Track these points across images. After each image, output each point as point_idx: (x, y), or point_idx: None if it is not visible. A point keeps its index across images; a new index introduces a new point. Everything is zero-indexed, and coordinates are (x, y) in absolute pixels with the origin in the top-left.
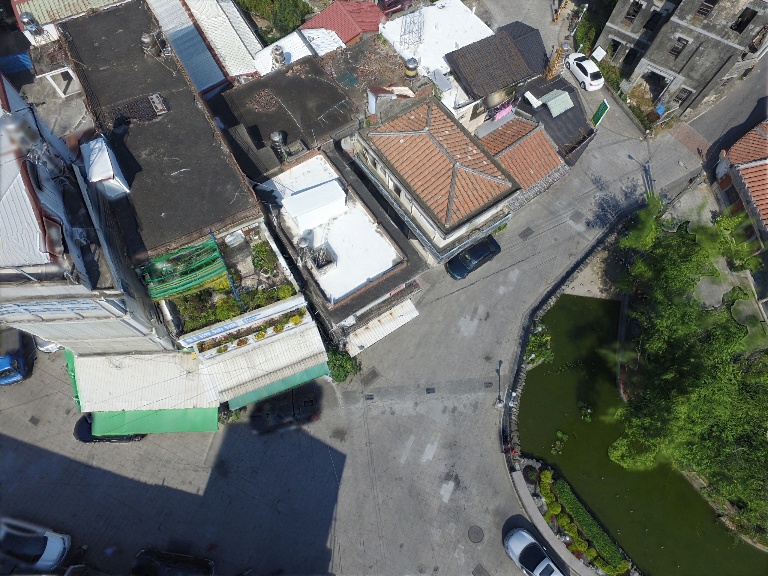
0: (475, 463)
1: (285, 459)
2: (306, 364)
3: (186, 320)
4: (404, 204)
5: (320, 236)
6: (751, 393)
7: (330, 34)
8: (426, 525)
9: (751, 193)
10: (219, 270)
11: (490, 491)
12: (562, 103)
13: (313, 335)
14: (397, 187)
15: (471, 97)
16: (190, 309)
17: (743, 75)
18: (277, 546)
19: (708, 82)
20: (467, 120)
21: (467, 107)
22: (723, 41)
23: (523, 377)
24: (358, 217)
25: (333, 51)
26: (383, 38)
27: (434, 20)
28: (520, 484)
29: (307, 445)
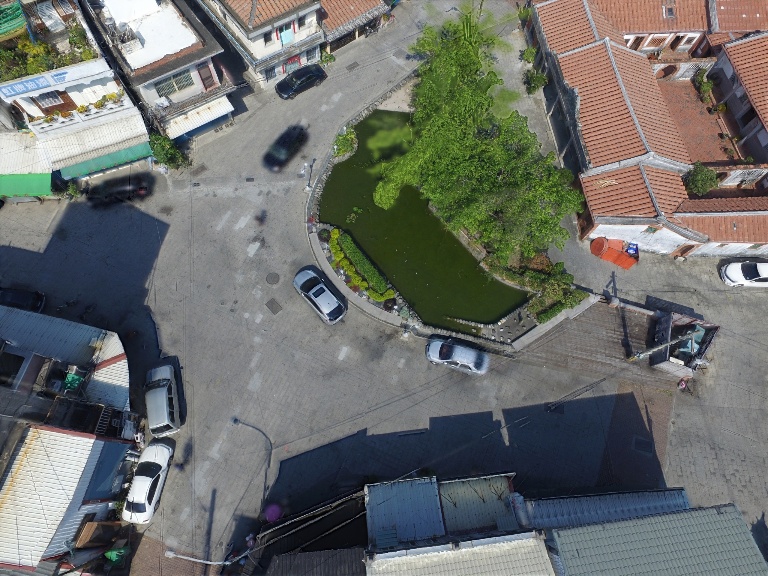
0: (280, 230)
1: (117, 228)
2: (130, 143)
3: (2, 74)
4: (231, 27)
5: (133, 27)
6: None
7: None
8: (231, 272)
9: (543, 25)
10: (20, 22)
11: (290, 249)
12: None
13: (137, 121)
14: (222, 10)
15: None
16: (5, 65)
17: None
18: (103, 287)
19: None
20: None
21: None
22: None
23: (330, 167)
24: (168, 14)
25: None
26: None
27: None
28: (314, 242)
29: (137, 218)
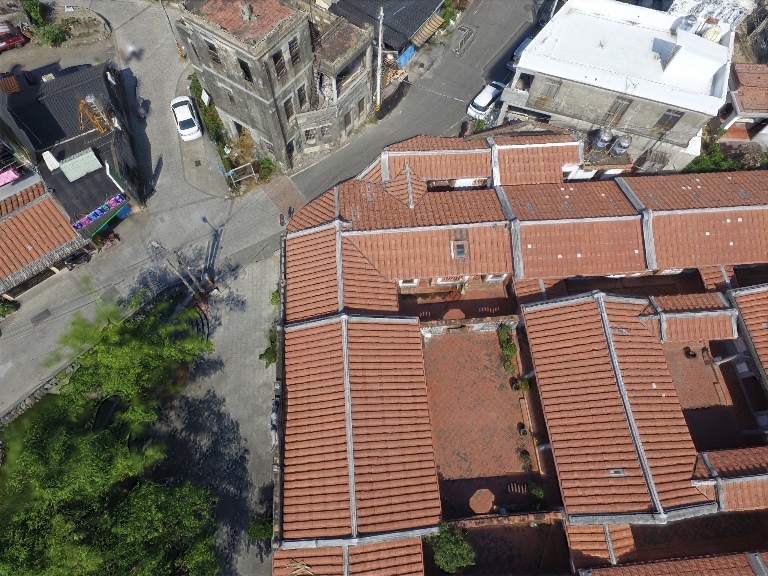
0: None
1: None
2: None
3: None
4: None
5: None
6: (102, 548)
7: None
8: None
9: (288, 269)
10: None
11: None
12: (84, 165)
13: None
14: None
15: None
16: None
17: (376, 118)
18: None
19: None
20: None
21: None
22: (249, 93)
23: None
24: None
25: None
26: None
27: None
28: None
29: None
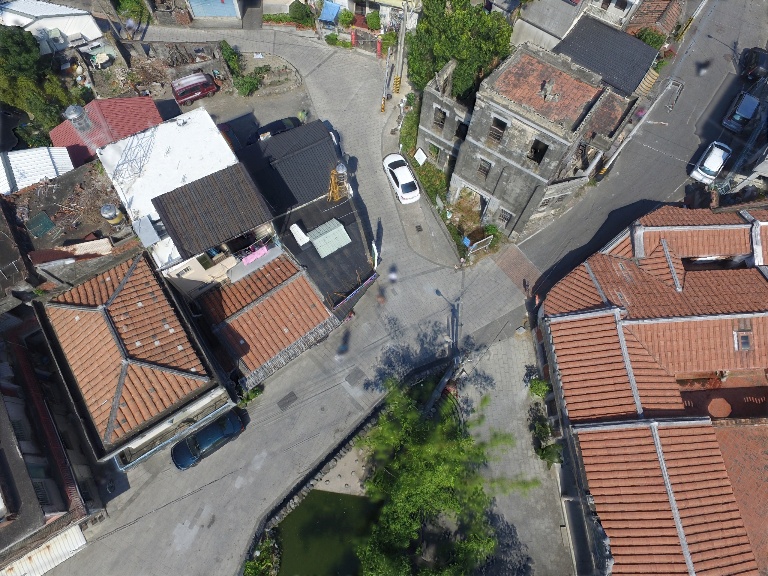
0: None
1: None
2: None
3: None
4: None
5: None
6: None
7: (54, 153)
8: None
9: (559, 358)
10: None
11: None
12: (335, 239)
13: None
14: None
15: (180, 255)
16: None
17: (596, 180)
18: None
19: (523, 208)
20: (199, 270)
21: (182, 263)
22: (524, 170)
23: None
24: None
25: (33, 185)
26: (101, 166)
27: (167, 143)
28: None
29: None
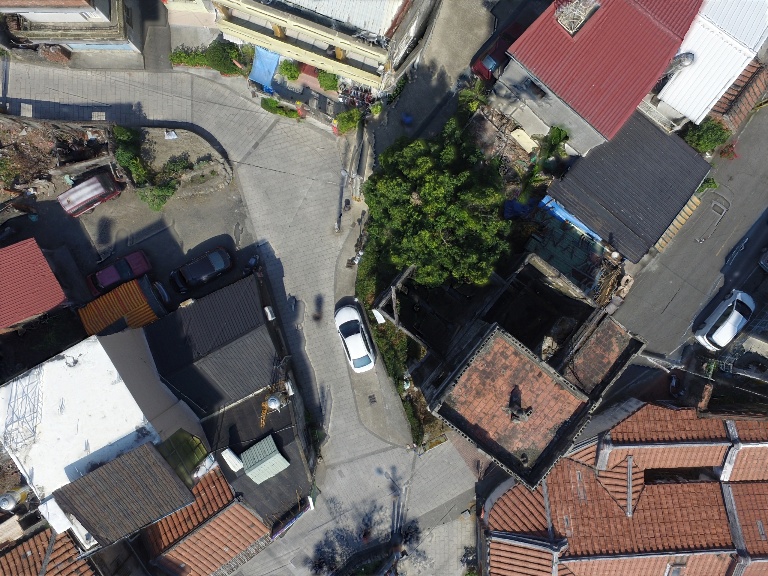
0: None
1: None
2: None
3: None
4: None
5: None
6: None
7: None
8: None
9: (493, 575)
10: None
11: None
12: (271, 466)
13: None
14: None
15: None
16: None
17: None
18: None
19: None
20: None
21: None
22: None
23: None
24: None
25: None
26: None
27: (58, 393)
28: None
29: None
